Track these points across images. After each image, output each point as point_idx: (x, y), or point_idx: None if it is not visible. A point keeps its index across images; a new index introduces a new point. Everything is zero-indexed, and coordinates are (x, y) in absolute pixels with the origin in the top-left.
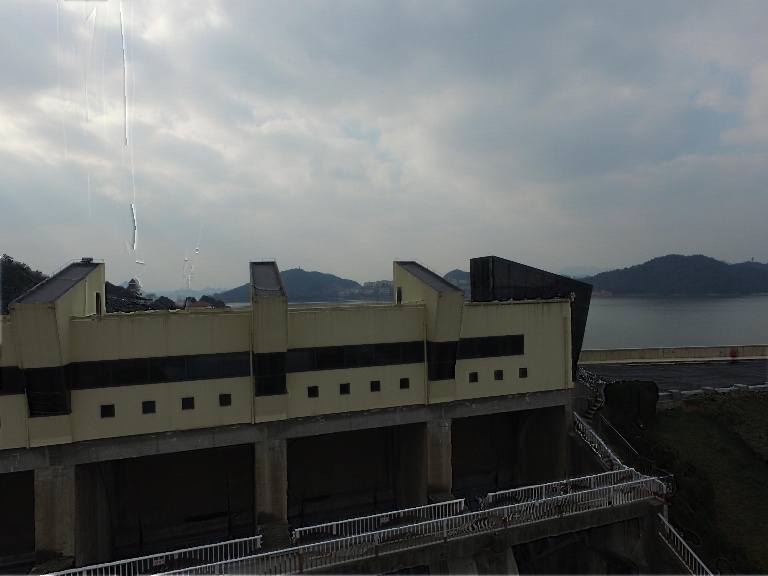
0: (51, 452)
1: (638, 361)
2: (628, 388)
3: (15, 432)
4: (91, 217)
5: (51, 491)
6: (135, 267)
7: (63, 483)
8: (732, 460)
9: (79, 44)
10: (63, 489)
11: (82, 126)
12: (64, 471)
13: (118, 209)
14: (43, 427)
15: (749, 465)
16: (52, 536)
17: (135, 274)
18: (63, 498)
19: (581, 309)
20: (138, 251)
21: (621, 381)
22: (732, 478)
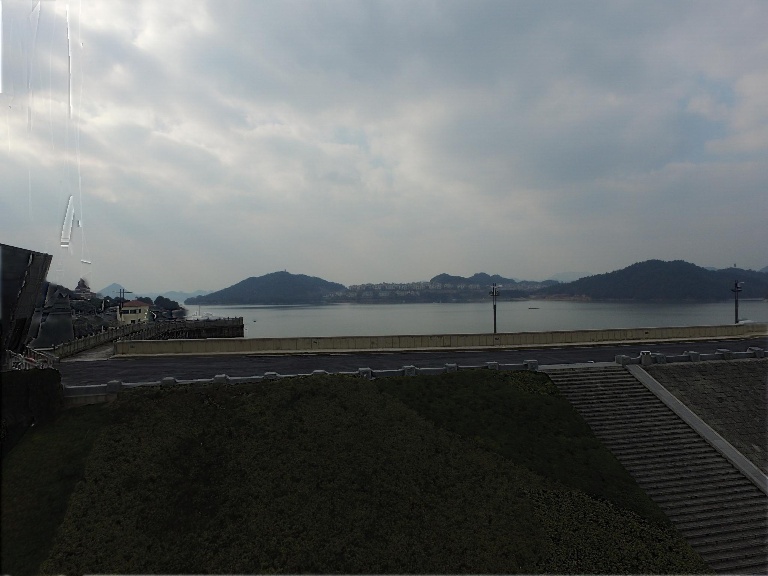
0: None
1: (263, 352)
2: (9, 377)
3: None
4: (31, 215)
5: None
6: (80, 266)
7: None
8: (59, 469)
9: (26, 39)
10: None
11: None
12: None
13: (60, 207)
14: None
15: (68, 476)
16: None
17: (80, 274)
18: None
19: (15, 280)
20: (84, 250)
21: (30, 369)
22: (33, 493)
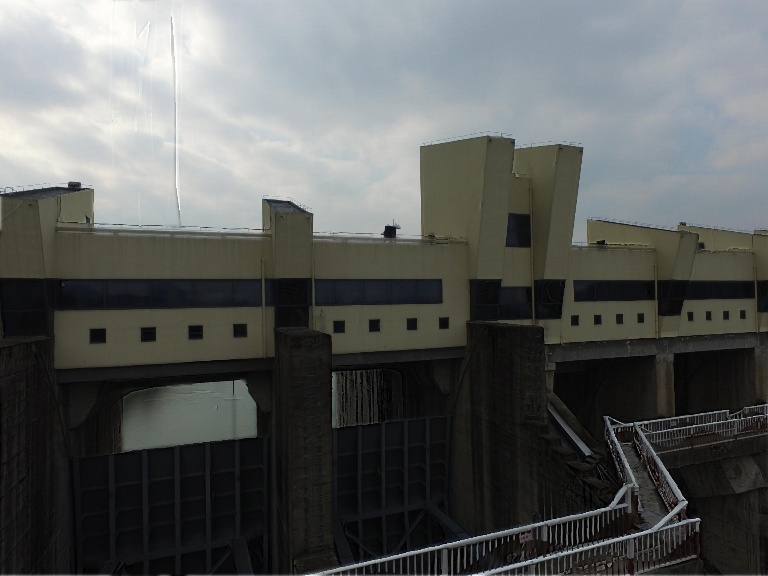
0: (760, 337)
1: None
2: None
3: (750, 322)
4: (141, 223)
5: (761, 362)
6: None
7: (765, 357)
8: None
9: (128, 56)
10: (765, 361)
11: (129, 135)
12: (765, 350)
13: (167, 216)
14: (766, 319)
15: None
16: (762, 391)
17: None
18: (765, 367)
19: None
20: None
21: None
22: None
